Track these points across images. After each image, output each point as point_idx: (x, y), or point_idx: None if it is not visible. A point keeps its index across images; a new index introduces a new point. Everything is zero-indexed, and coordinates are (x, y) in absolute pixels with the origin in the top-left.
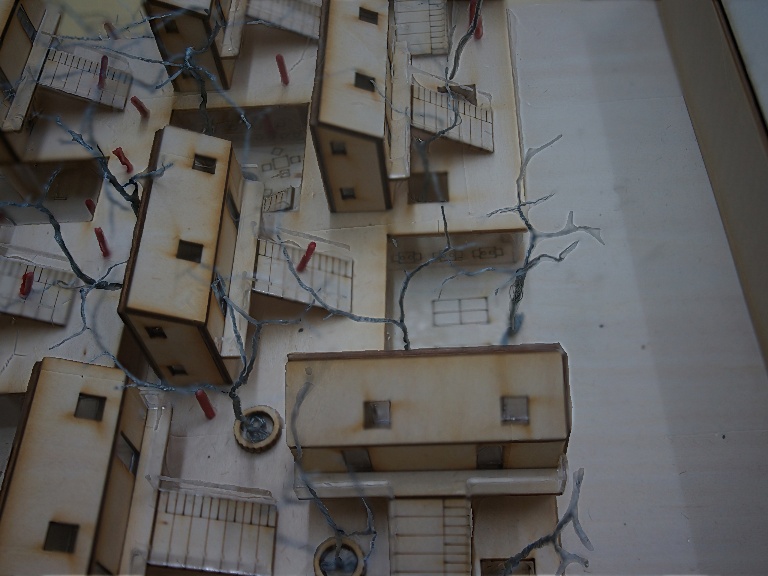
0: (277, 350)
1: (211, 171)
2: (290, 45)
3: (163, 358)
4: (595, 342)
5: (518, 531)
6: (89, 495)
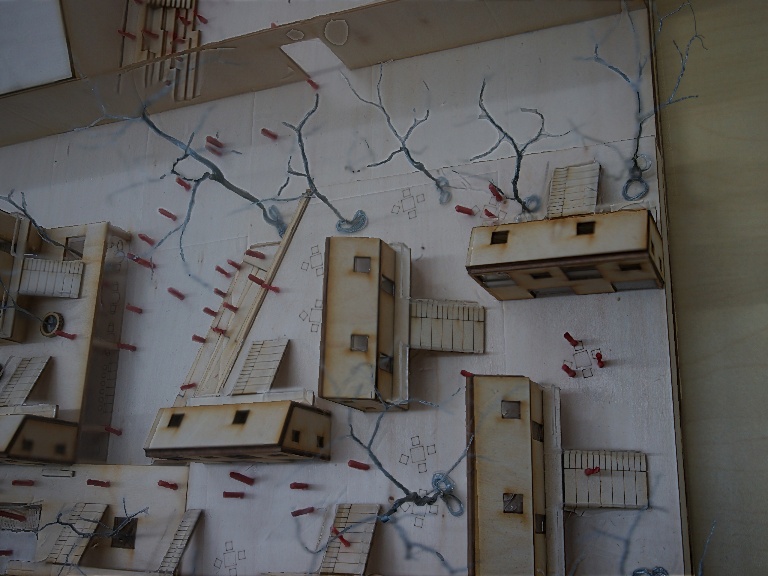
0: None
1: None
2: None
3: None
4: None
5: None
6: None
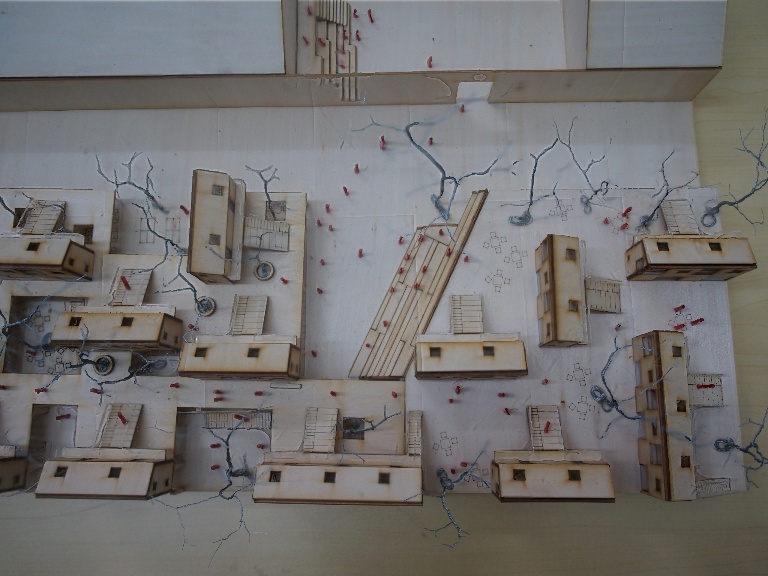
0: (167, 302)
1: (80, 319)
2: None
3: (172, 342)
4: (171, 174)
5: (256, 206)
6: (238, 347)
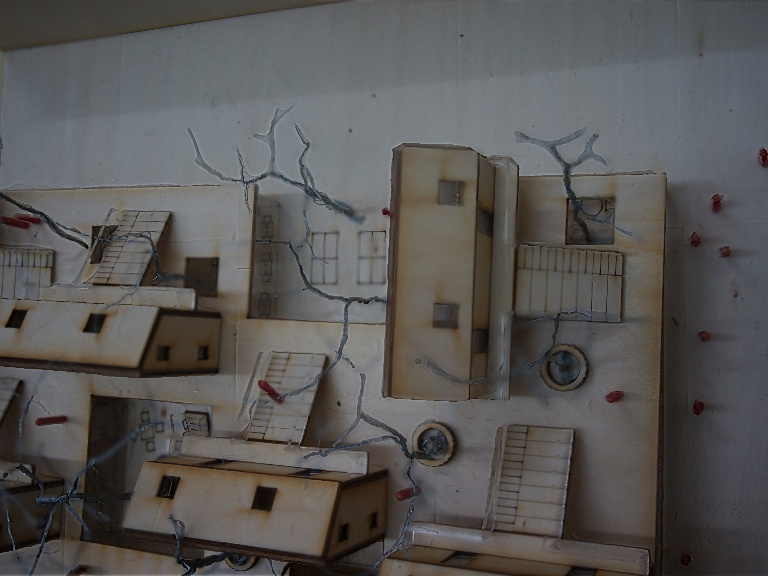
0: (357, 427)
1: (177, 481)
2: (19, 415)
3: (363, 532)
4: (365, 138)
5: (542, 211)
6: None
